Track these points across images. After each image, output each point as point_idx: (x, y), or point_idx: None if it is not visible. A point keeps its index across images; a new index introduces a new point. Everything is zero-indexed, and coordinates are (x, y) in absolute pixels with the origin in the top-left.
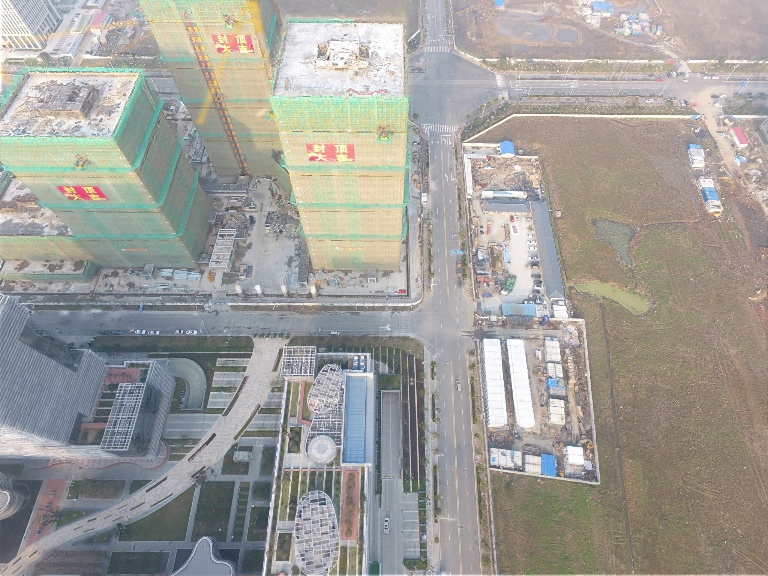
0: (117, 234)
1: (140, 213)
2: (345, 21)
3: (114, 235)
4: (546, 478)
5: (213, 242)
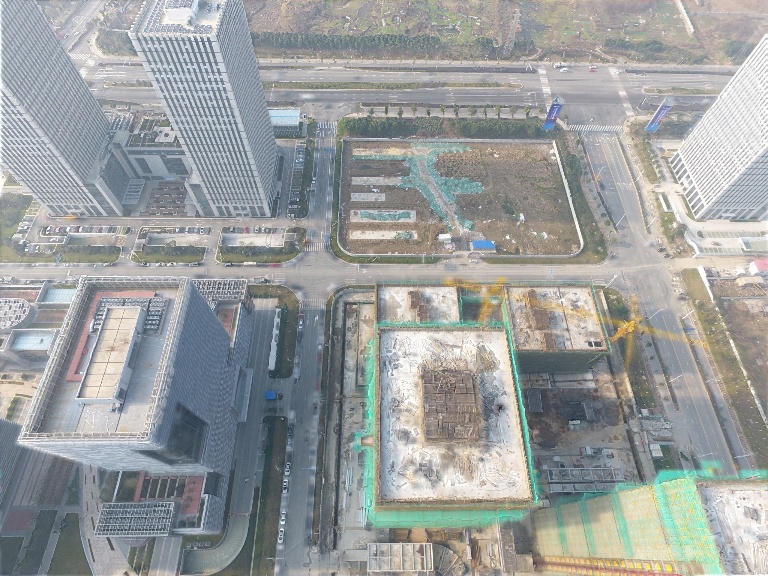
0: None
1: None
2: None
3: None
4: None
5: (416, 533)
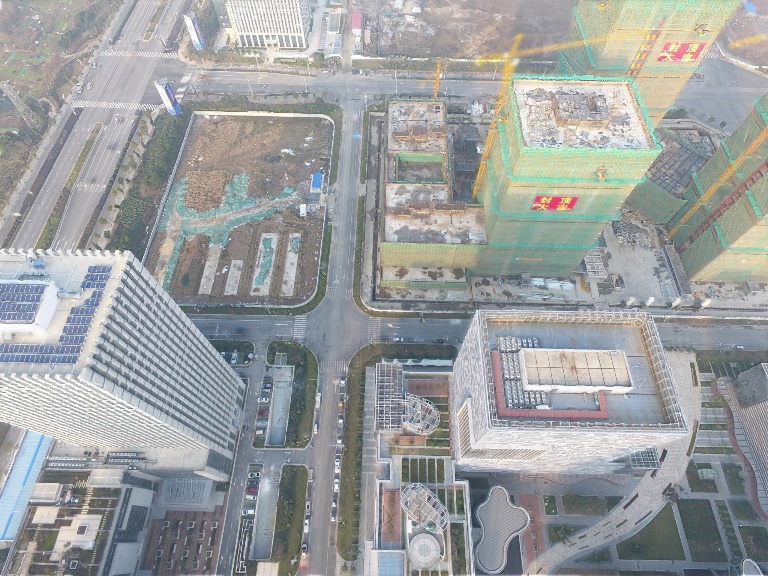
0: (533, 243)
1: (585, 224)
2: None
3: (530, 244)
4: None
5: None
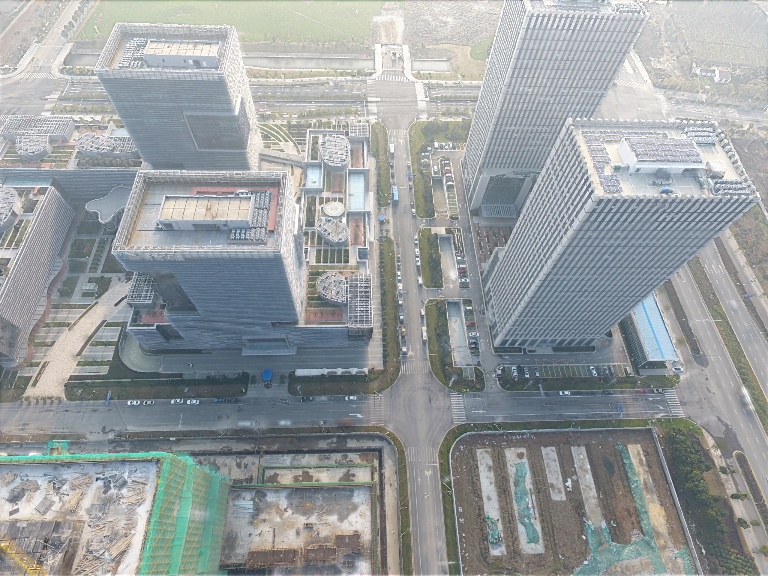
0: None
1: None
2: None
3: None
4: None
5: None
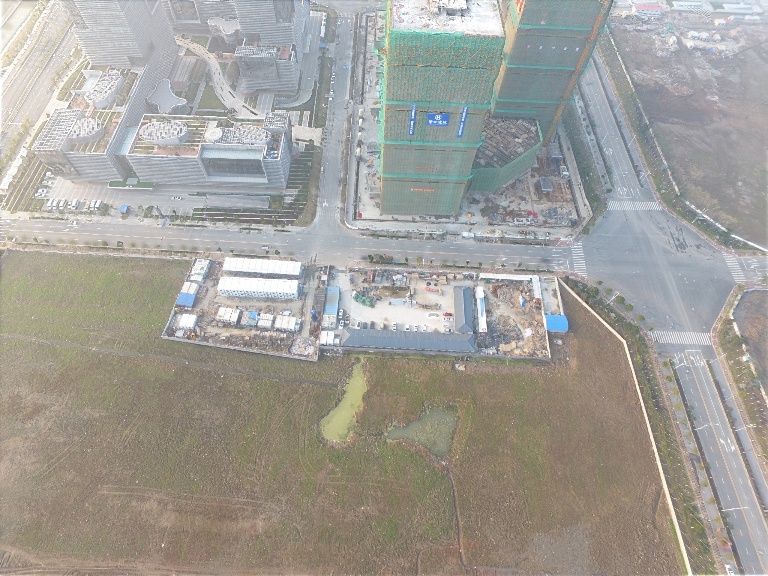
0: None
1: None
2: (499, 4)
3: None
4: None
5: None
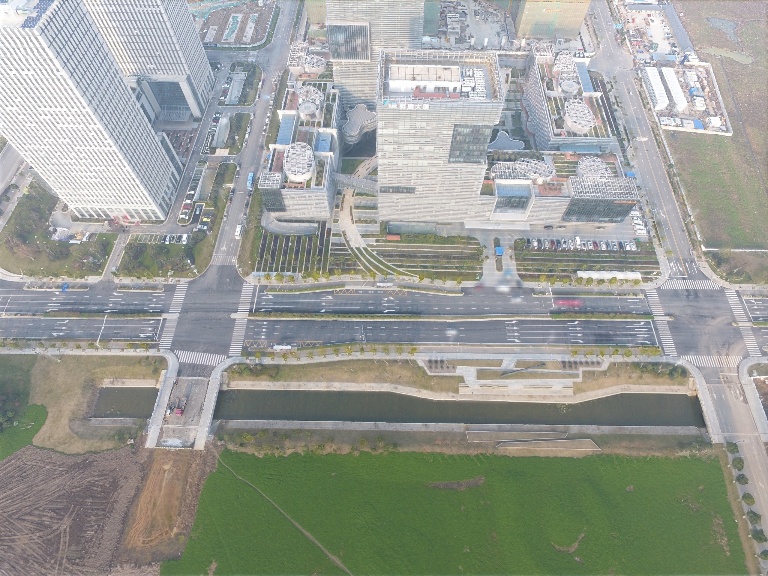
0: None
1: None
2: None
3: None
4: (697, 133)
5: (442, 23)
